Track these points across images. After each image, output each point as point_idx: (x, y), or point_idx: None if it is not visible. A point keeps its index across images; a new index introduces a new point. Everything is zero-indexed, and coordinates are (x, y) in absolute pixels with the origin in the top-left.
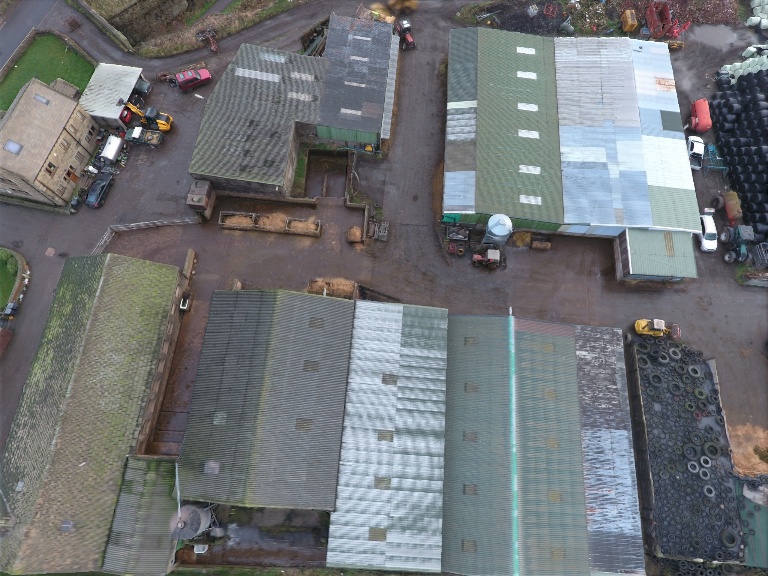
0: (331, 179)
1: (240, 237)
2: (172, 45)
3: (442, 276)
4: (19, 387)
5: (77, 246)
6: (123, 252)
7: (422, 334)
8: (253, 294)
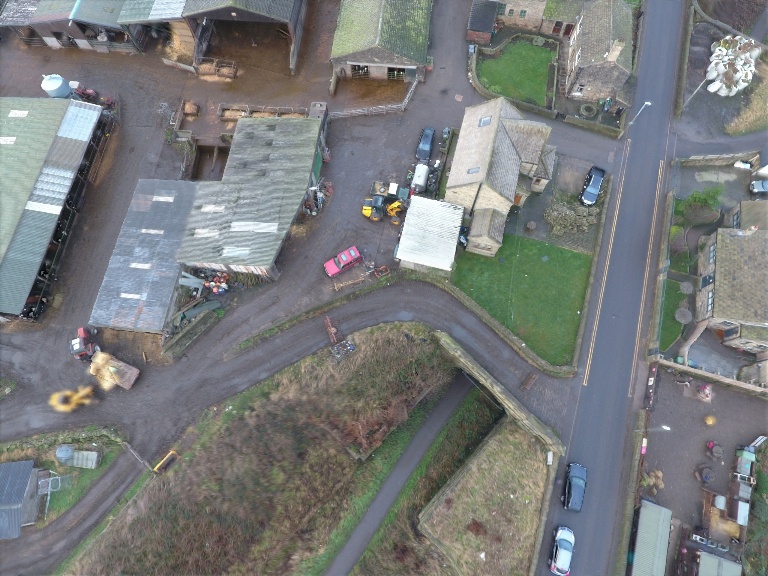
0: (212, 178)
1: (294, 111)
2: (385, 333)
3: (127, 86)
4: (449, 8)
5: (436, 101)
6: (393, 95)
7: (140, 5)
8: (254, 8)
